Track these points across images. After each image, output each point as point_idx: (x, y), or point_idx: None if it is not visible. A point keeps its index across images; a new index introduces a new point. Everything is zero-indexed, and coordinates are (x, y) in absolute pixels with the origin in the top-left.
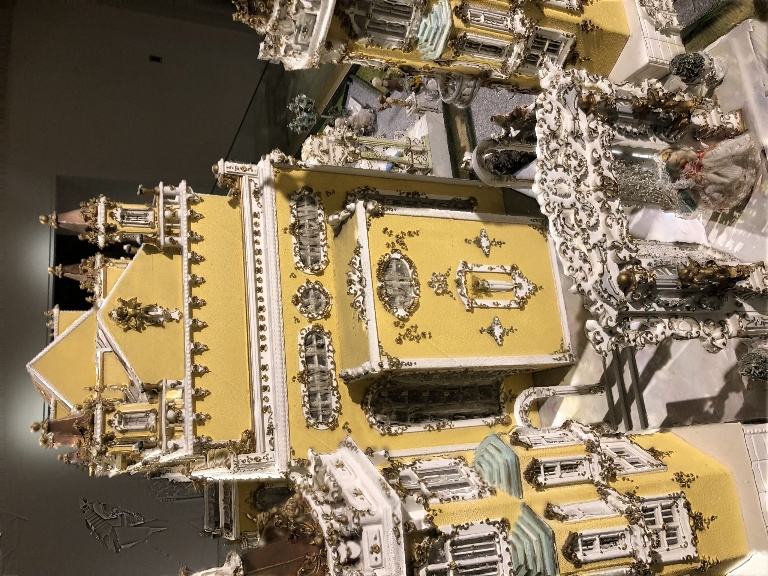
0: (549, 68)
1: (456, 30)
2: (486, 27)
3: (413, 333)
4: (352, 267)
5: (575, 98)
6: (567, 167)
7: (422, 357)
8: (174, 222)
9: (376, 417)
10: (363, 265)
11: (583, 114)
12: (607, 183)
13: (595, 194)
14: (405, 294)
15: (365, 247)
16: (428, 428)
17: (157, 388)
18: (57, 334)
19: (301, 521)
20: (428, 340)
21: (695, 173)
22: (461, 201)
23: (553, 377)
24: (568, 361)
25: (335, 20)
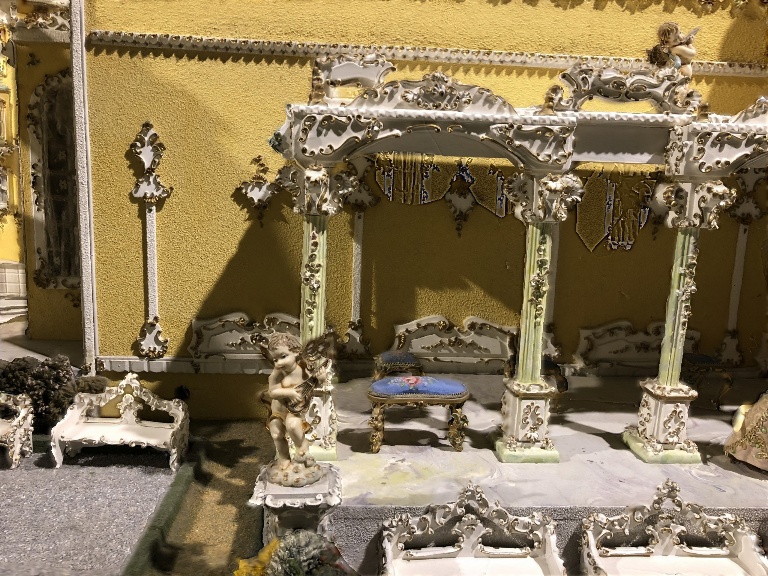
0: None
1: None
2: None
3: None
4: None
5: None
6: None
7: None
8: None
9: None
10: None
11: None
12: None
13: None
14: None
15: None
16: None
17: None
18: None
19: None
20: None
21: None
22: None
23: None
24: None
25: None
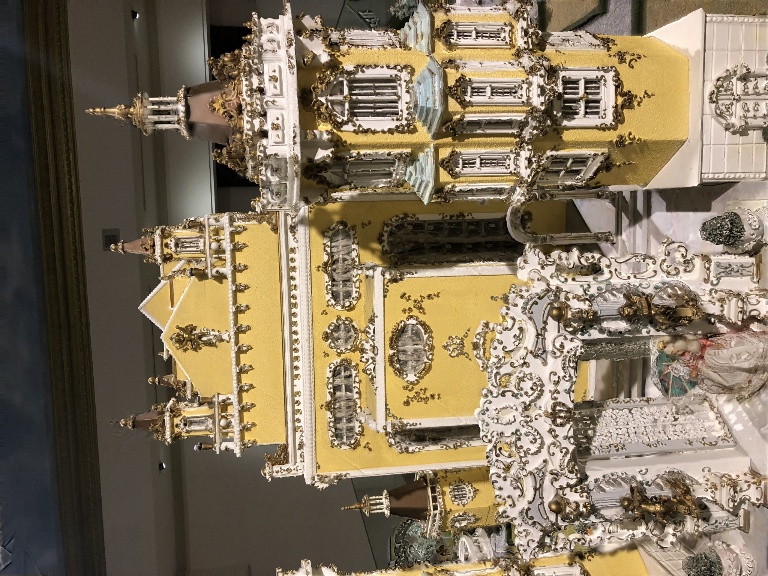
0: (528, 260)
1: (442, 183)
2: (480, 174)
3: (422, 395)
4: (366, 336)
5: (546, 306)
6: (517, 391)
7: (428, 417)
8: (220, 253)
9: (396, 438)
10: (376, 334)
11: (554, 322)
12: (558, 410)
13: (544, 417)
14: (418, 357)
15: (380, 316)
16: (445, 447)
17: (211, 402)
18: (163, 272)
19: None
20: (436, 401)
21: (693, 365)
22: None
23: None
24: None
25: (308, 181)
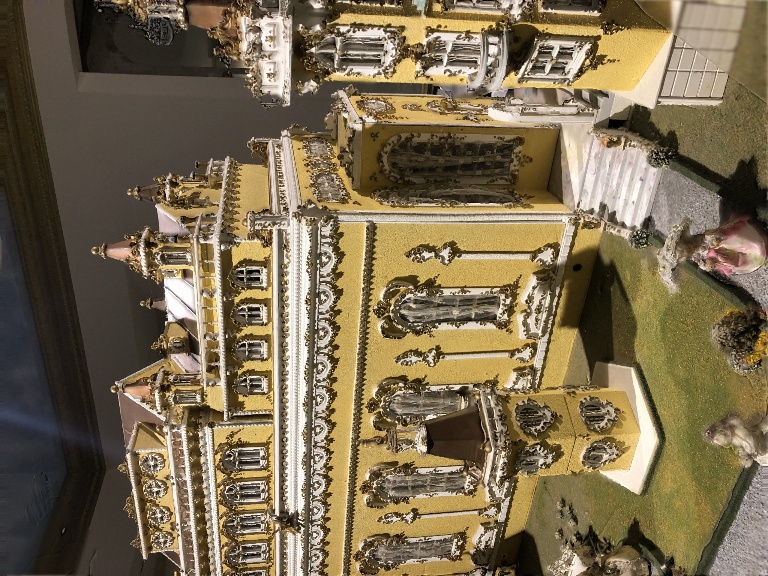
0: None
1: None
2: None
3: None
4: None
5: None
6: None
7: None
8: None
9: None
10: None
11: None
12: None
13: None
14: None
15: None
16: (440, 205)
17: (195, 219)
18: None
19: None
20: None
21: None
22: None
23: (556, 164)
24: (551, 128)
25: None
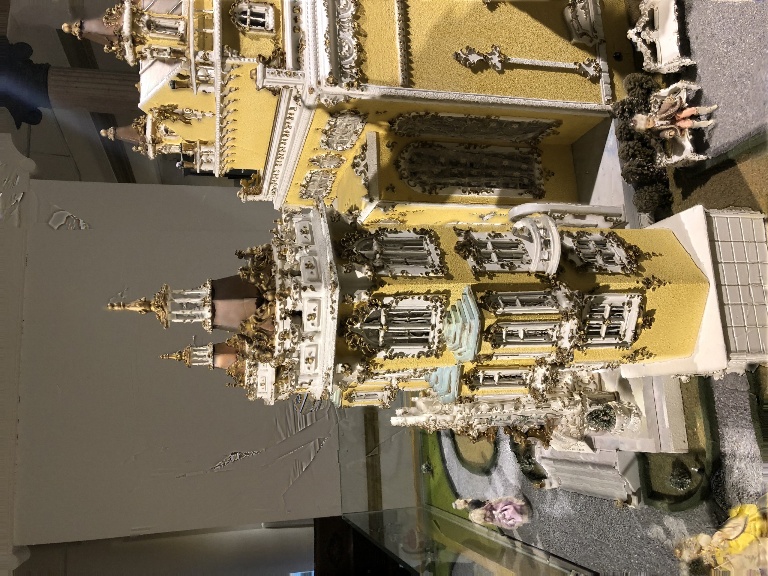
0: None
1: None
2: None
3: None
4: None
5: None
6: None
7: None
8: None
9: None
10: None
11: None
12: None
13: None
14: None
15: (365, 216)
16: None
17: None
18: None
19: (238, 373)
20: None
21: None
22: (541, 123)
23: None
24: None
25: None
